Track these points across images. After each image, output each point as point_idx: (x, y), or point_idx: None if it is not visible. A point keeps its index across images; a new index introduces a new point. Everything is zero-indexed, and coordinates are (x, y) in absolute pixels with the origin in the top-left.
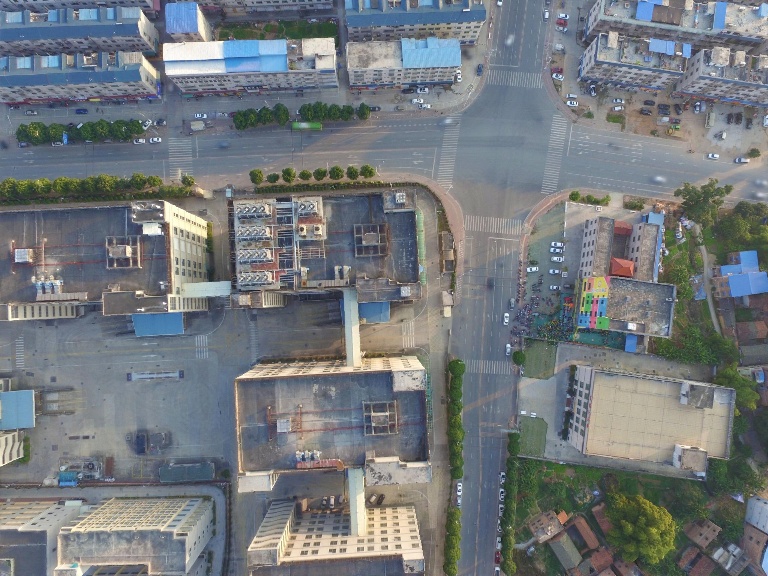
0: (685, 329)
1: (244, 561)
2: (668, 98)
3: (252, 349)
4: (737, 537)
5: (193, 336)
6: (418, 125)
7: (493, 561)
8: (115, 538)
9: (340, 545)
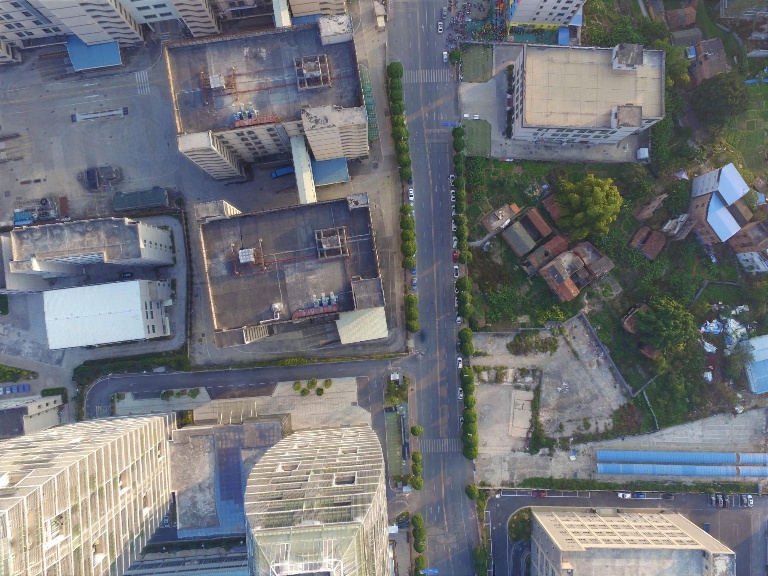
0: None
1: None
2: None
3: None
4: (683, 206)
5: (133, 73)
6: None
7: (451, 261)
8: (68, 232)
9: None
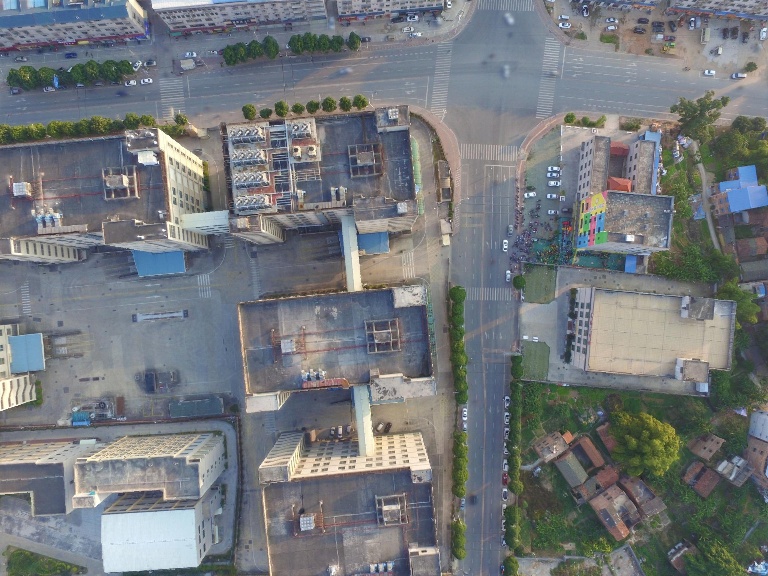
0: (685, 247)
1: (257, 492)
2: (662, 15)
3: (254, 286)
4: (741, 449)
5: (195, 275)
6: (409, 54)
7: (500, 483)
8: (130, 466)
9: (349, 463)
